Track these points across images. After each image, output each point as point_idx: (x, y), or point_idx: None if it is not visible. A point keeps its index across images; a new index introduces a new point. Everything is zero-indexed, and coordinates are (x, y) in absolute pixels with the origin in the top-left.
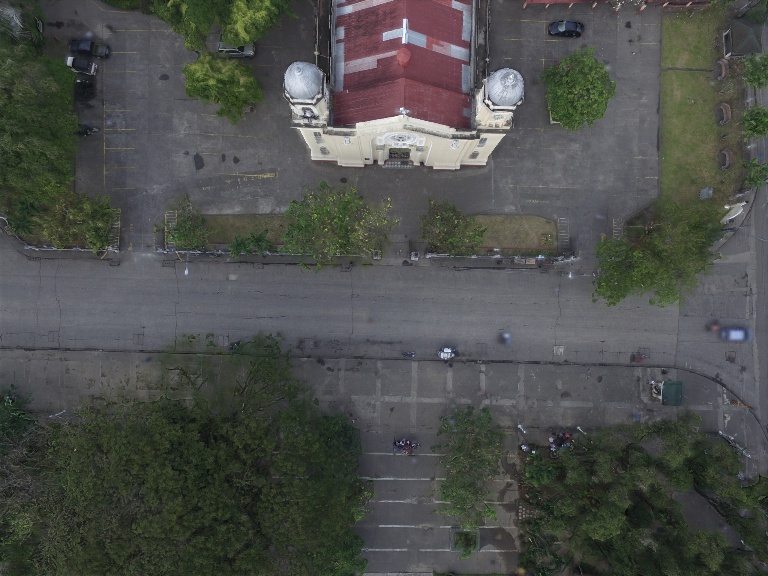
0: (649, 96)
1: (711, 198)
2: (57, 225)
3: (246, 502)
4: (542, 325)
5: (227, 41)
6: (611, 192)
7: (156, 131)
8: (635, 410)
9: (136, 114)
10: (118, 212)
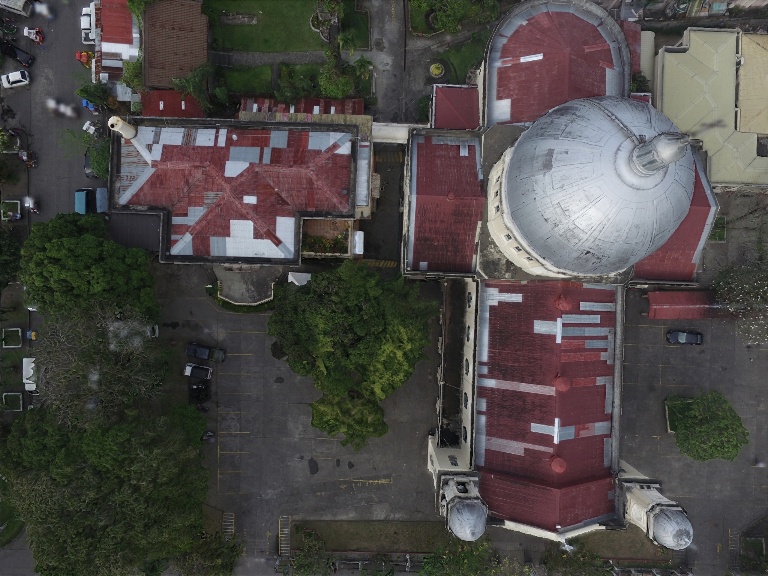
0: (767, 403)
1: None
2: None
3: None
4: None
5: None
6: (727, 501)
7: (271, 435)
8: None
9: (251, 417)
10: (232, 517)
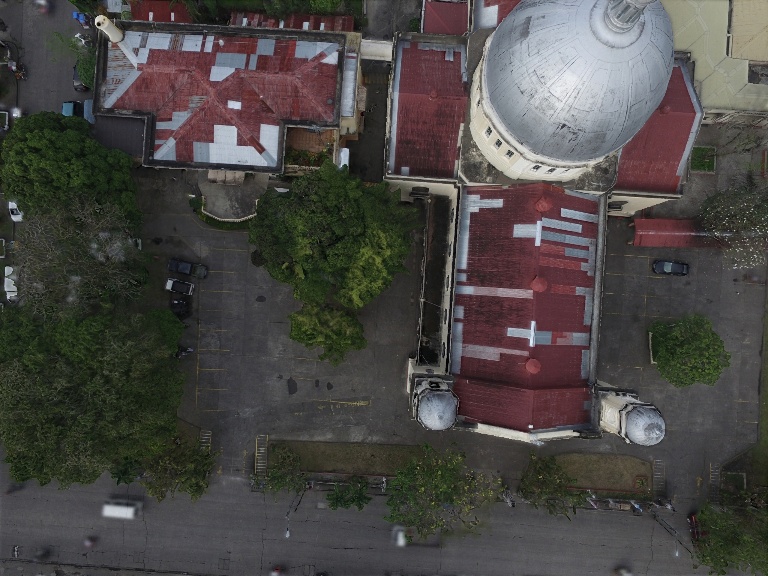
0: (752, 338)
1: None
2: (161, 485)
3: None
4: (633, 569)
5: None
6: (709, 435)
7: (250, 353)
8: None
9: (231, 335)
10: (209, 434)
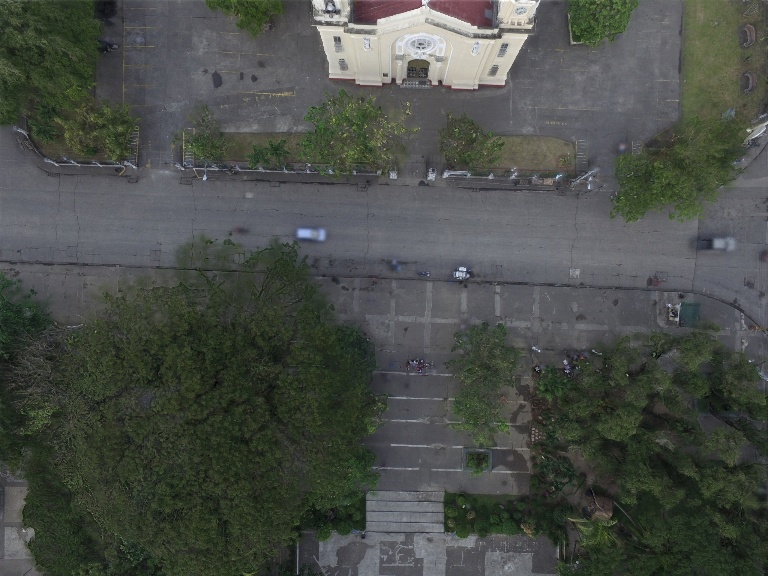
0: (671, 18)
1: (733, 121)
2: (78, 128)
3: (263, 387)
4: (558, 247)
5: None
6: (631, 114)
7: (175, 49)
8: (651, 334)
9: (155, 32)
10: (137, 129)
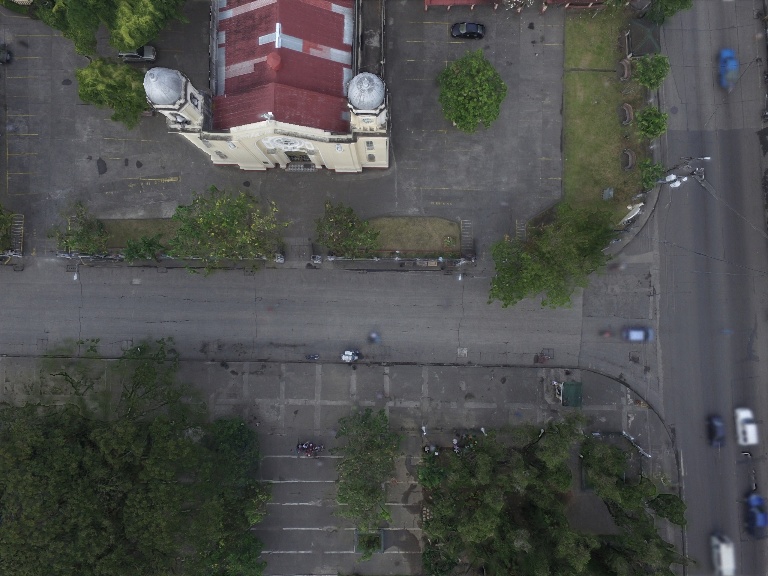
0: (552, 97)
1: (614, 199)
2: None
3: (111, 507)
4: (446, 327)
5: (115, 46)
6: (514, 193)
7: (59, 136)
8: (539, 411)
9: (39, 119)
10: (21, 217)
